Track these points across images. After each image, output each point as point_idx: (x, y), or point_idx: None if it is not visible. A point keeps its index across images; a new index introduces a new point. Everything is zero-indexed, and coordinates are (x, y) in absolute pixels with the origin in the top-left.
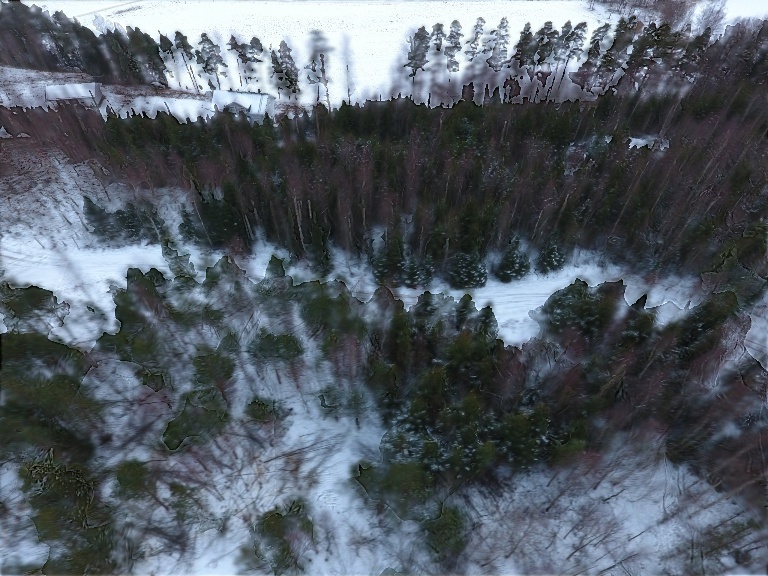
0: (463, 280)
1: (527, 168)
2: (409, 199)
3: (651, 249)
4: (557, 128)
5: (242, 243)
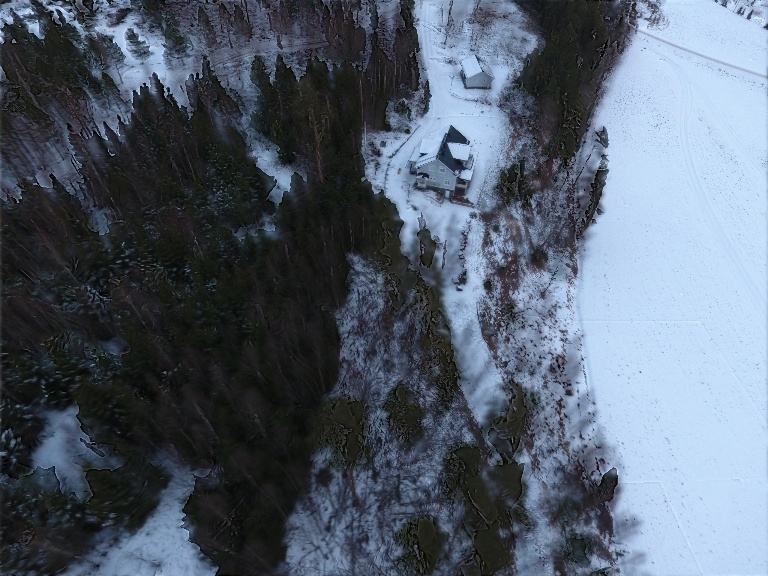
0: None
1: None
2: None
3: None
4: None
5: None
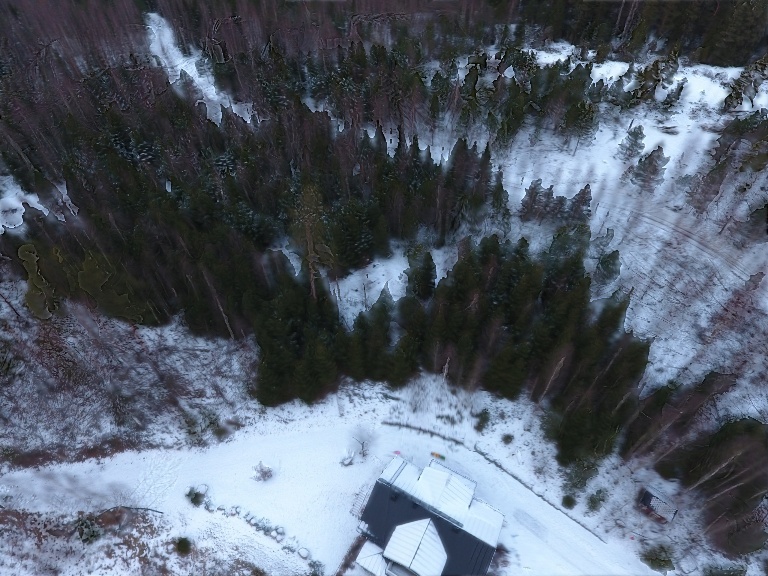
0: None
1: None
2: None
3: None
4: (126, 162)
5: None
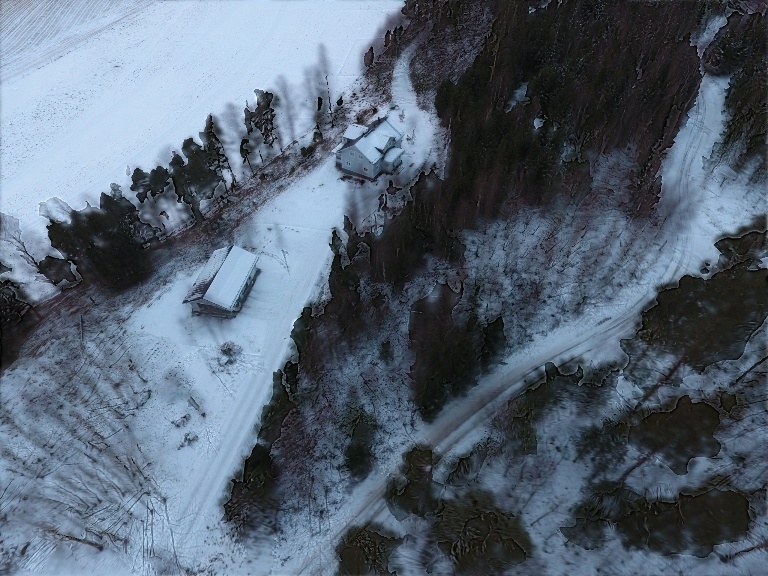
0: None
1: None
2: None
3: None
4: (574, 7)
5: None
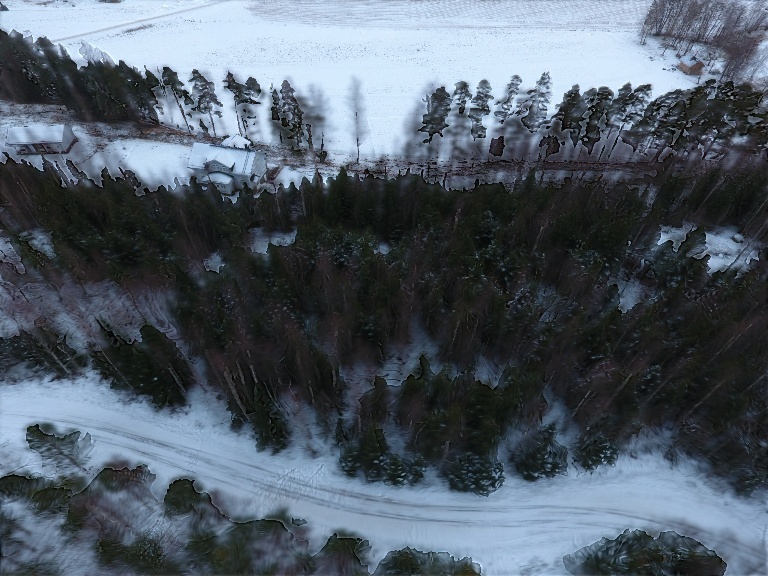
0: (468, 487)
1: (567, 281)
2: (406, 326)
3: (752, 459)
4: (611, 237)
5: (170, 394)
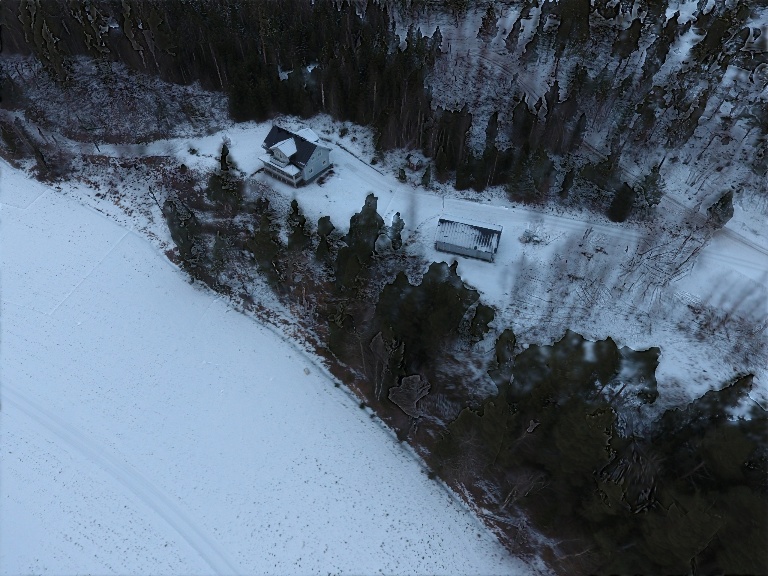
0: None
1: None
2: None
3: None
4: None
5: None
